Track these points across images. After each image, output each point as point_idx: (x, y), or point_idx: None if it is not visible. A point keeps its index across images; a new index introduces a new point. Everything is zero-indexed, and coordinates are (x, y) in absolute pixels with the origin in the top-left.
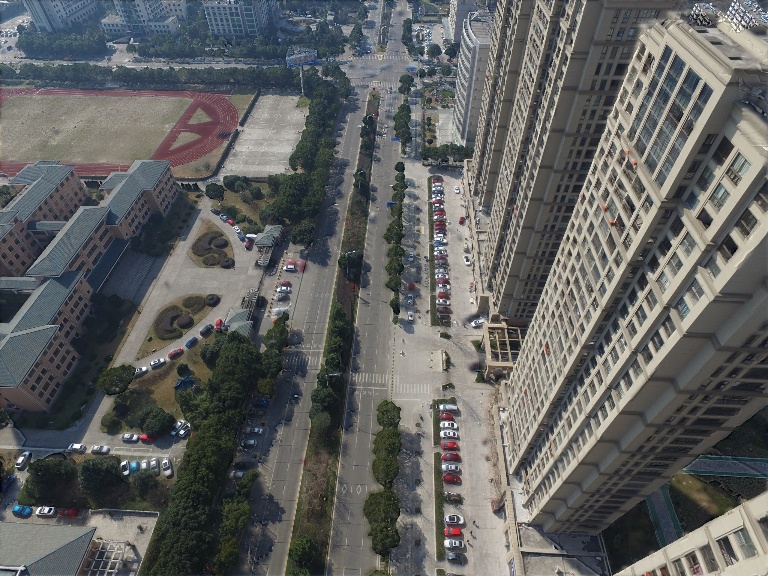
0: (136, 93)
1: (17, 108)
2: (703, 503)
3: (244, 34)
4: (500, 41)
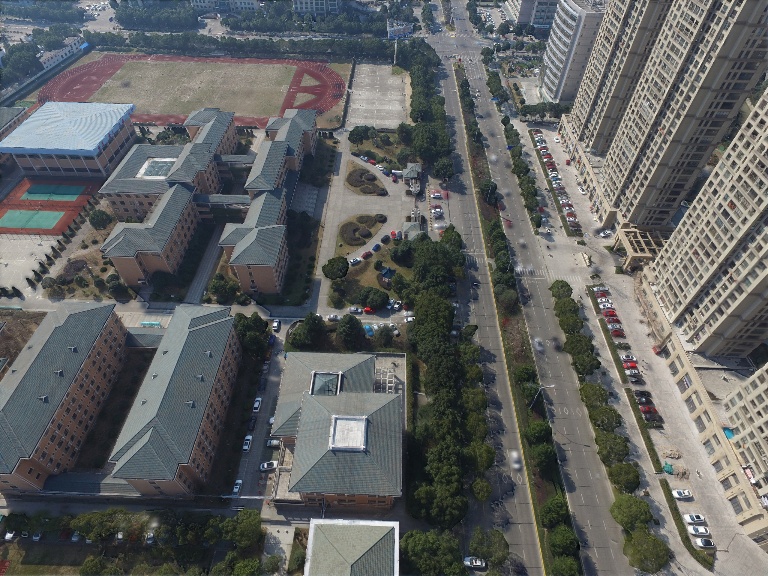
0: (242, 60)
1: (138, 71)
2: None
3: (325, 12)
4: (629, 4)
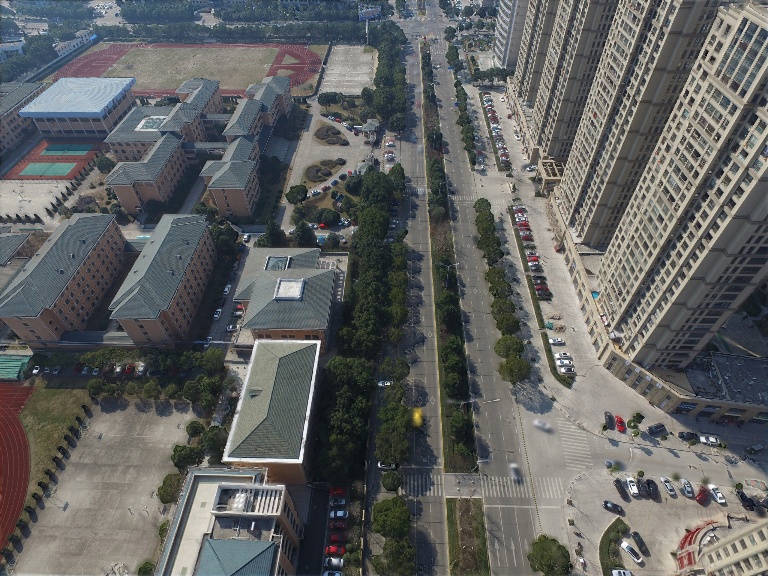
0: (231, 45)
1: (140, 56)
2: None
3: (308, 3)
4: None
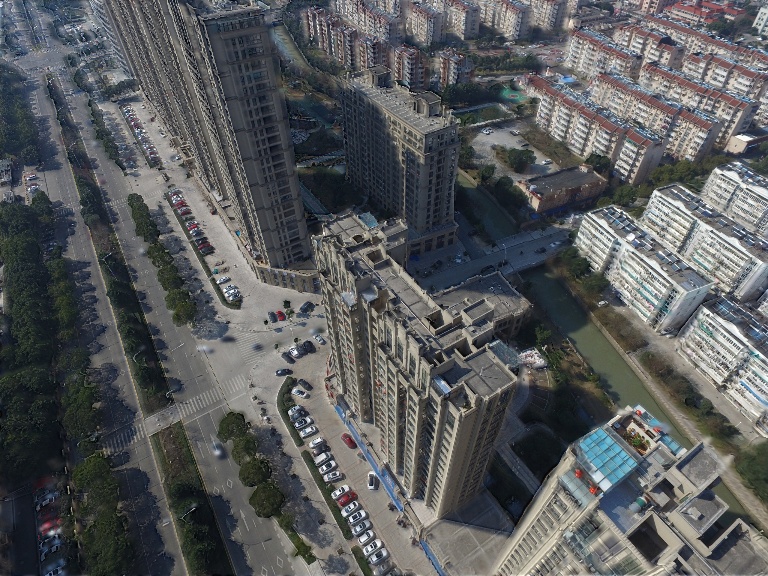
0: None
1: None
2: (310, 173)
3: None
4: None
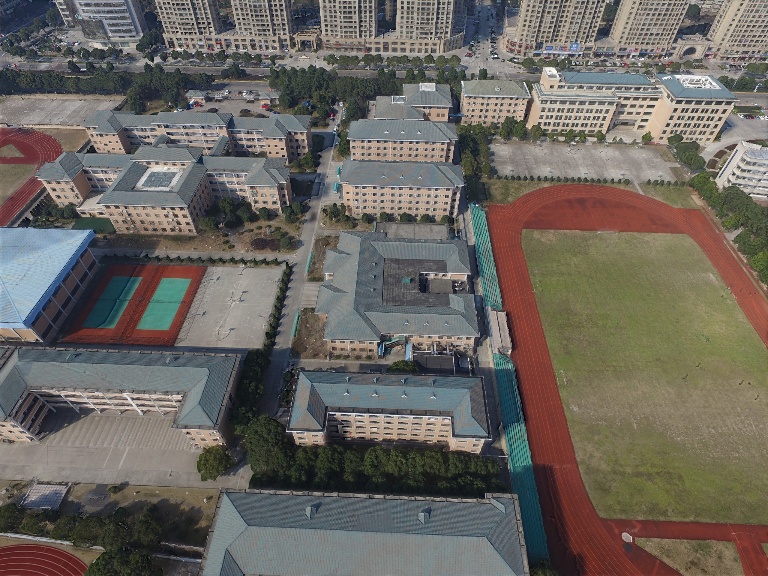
0: None
1: None
2: None
3: None
4: None
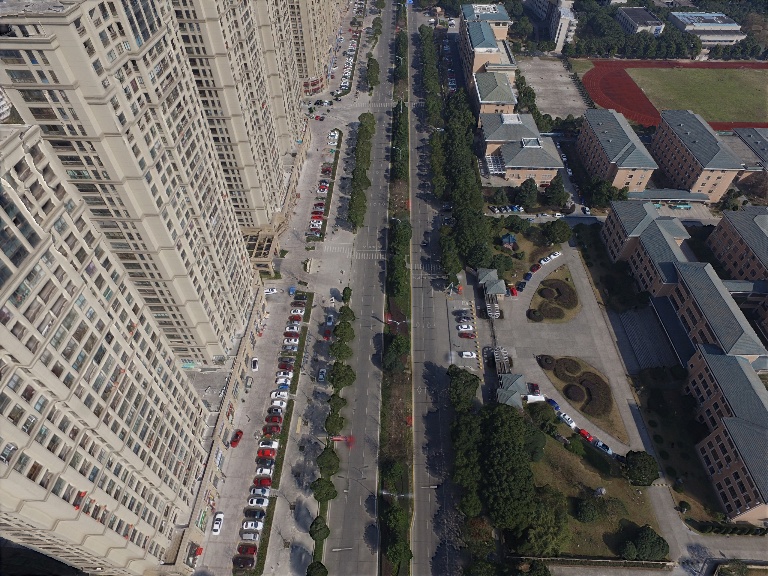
0: None
1: None
2: None
3: None
4: None
